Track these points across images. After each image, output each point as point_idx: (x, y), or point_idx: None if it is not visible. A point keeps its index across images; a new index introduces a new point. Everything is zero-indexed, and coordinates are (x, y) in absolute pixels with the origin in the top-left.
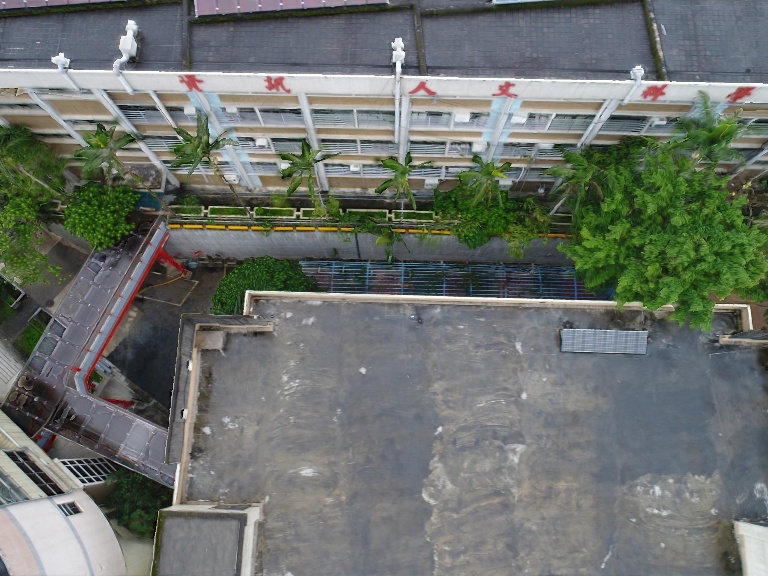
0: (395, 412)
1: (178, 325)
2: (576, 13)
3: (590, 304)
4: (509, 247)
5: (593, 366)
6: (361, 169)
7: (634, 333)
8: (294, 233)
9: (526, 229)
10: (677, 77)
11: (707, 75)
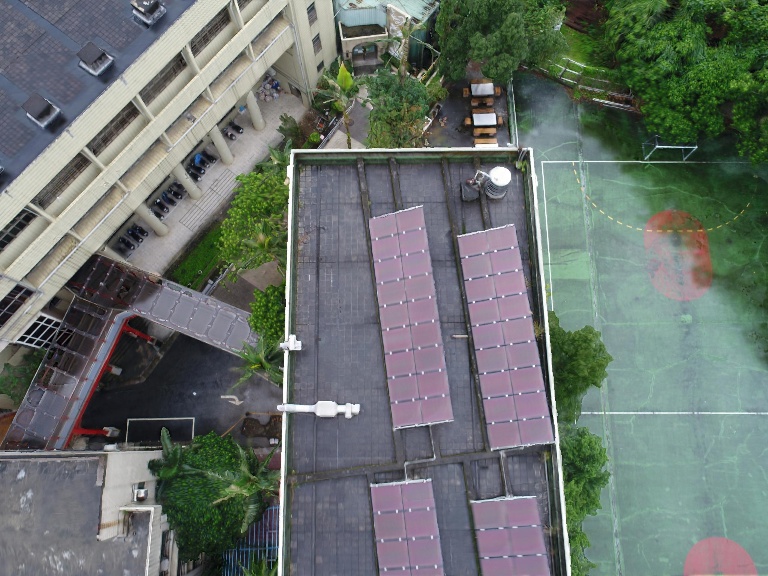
0: None
1: (234, 371)
2: None
3: None
4: None
5: None
6: None
7: None
8: None
9: None
10: None
11: None
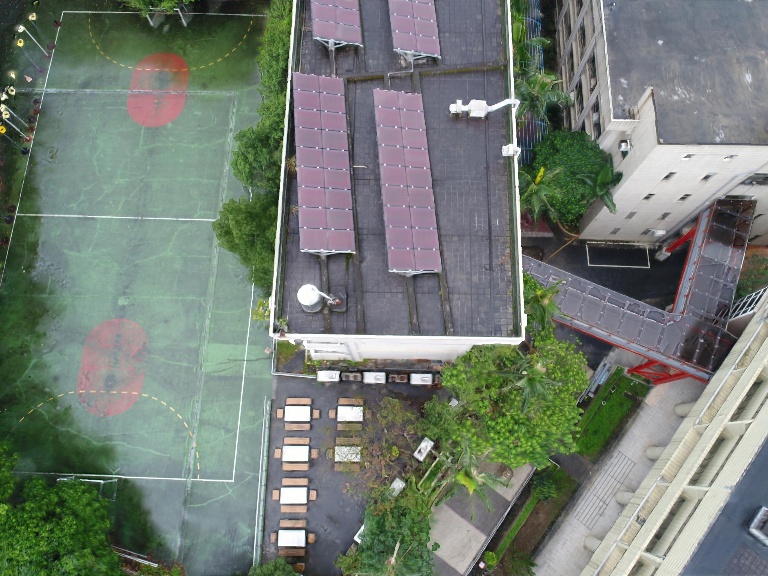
0: (690, 20)
1: None
2: None
3: None
4: None
5: None
6: None
7: None
8: None
9: None
10: None
11: None
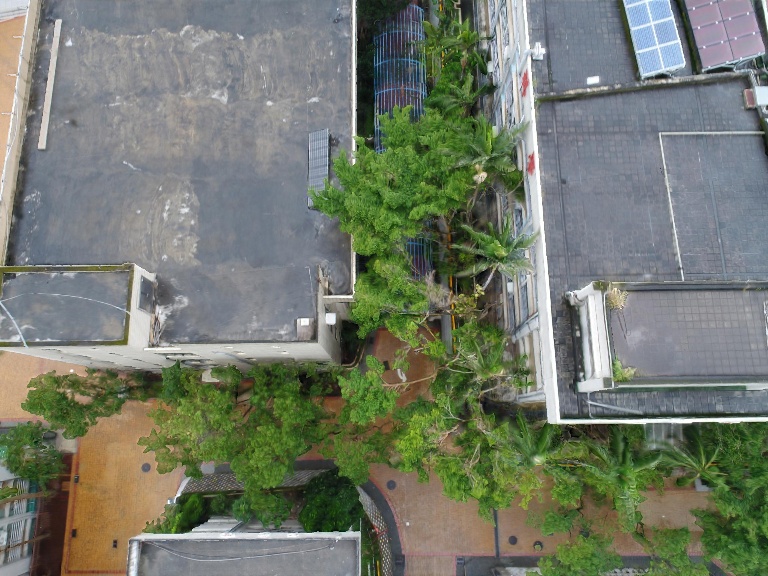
0: (256, 4)
1: None
2: (613, 22)
3: None
4: None
5: (297, 162)
6: None
7: None
8: None
9: None
10: (548, 111)
11: (553, 140)
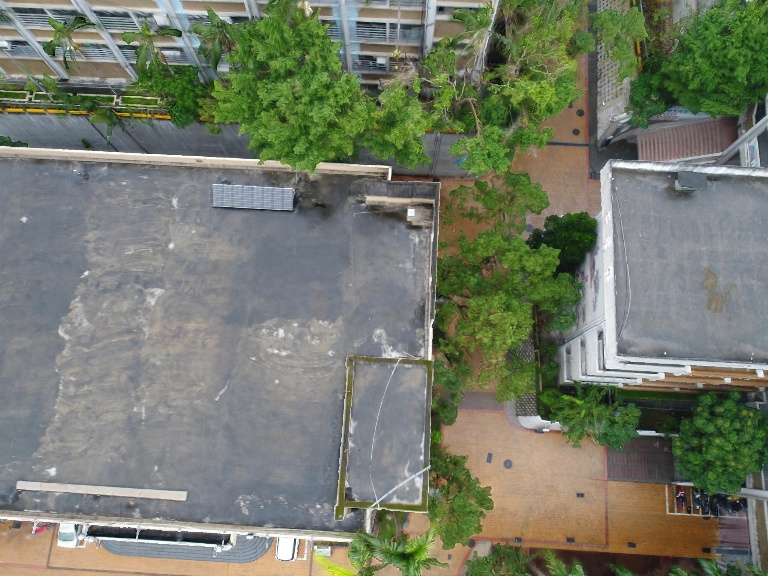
0: (47, 257)
1: None
2: None
3: (247, 165)
4: (243, 139)
5: (242, 221)
6: (77, 50)
7: (279, 190)
8: (29, 116)
9: (215, 103)
10: None
11: None
